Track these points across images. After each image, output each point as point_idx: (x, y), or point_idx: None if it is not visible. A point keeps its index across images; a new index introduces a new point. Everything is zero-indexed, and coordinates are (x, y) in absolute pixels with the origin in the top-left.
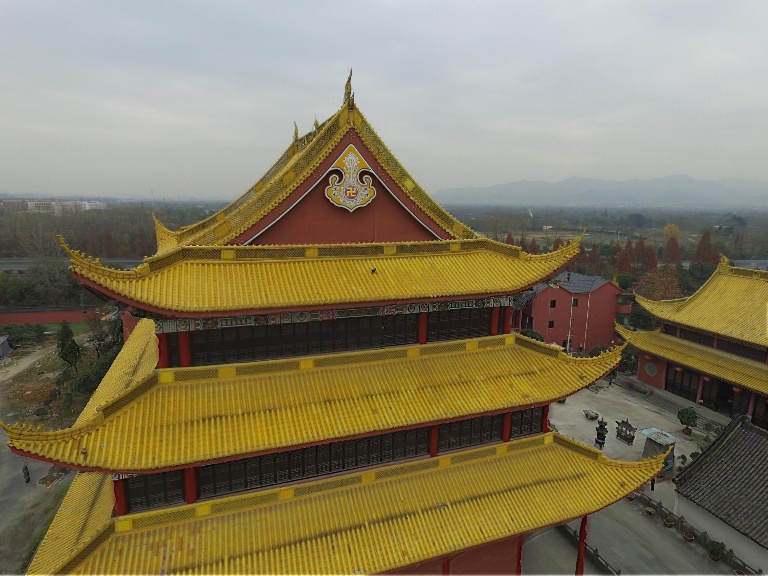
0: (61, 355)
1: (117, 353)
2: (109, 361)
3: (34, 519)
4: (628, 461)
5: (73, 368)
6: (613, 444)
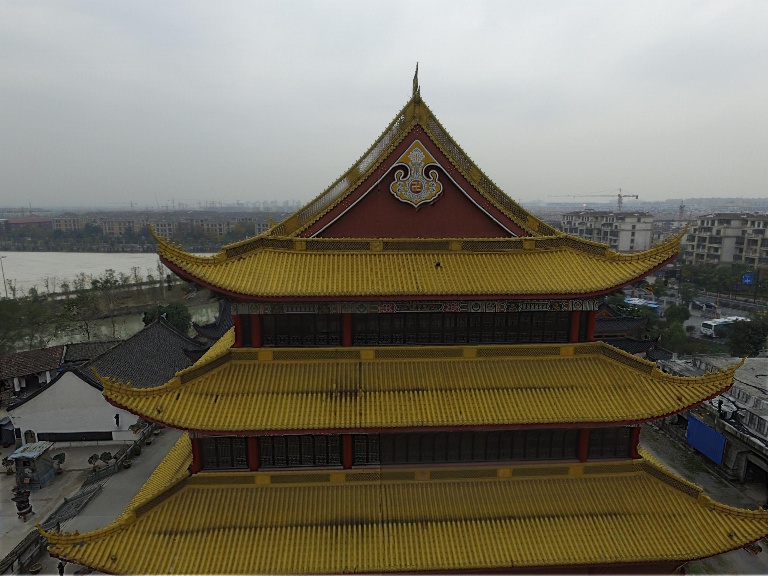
0: None
1: None
2: None
3: None
4: (45, 493)
5: None
6: (2, 518)
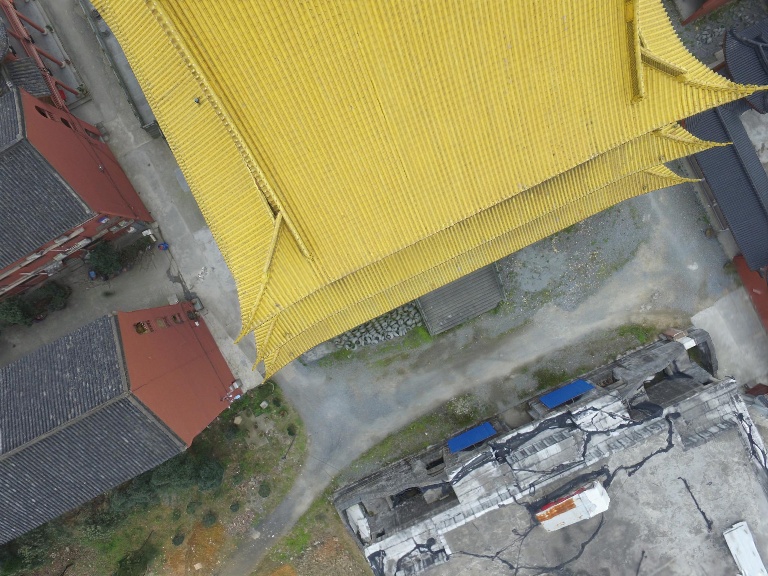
0: (145, 571)
1: (136, 487)
2: (171, 475)
3: (416, 359)
4: None
5: (114, 573)
6: None
